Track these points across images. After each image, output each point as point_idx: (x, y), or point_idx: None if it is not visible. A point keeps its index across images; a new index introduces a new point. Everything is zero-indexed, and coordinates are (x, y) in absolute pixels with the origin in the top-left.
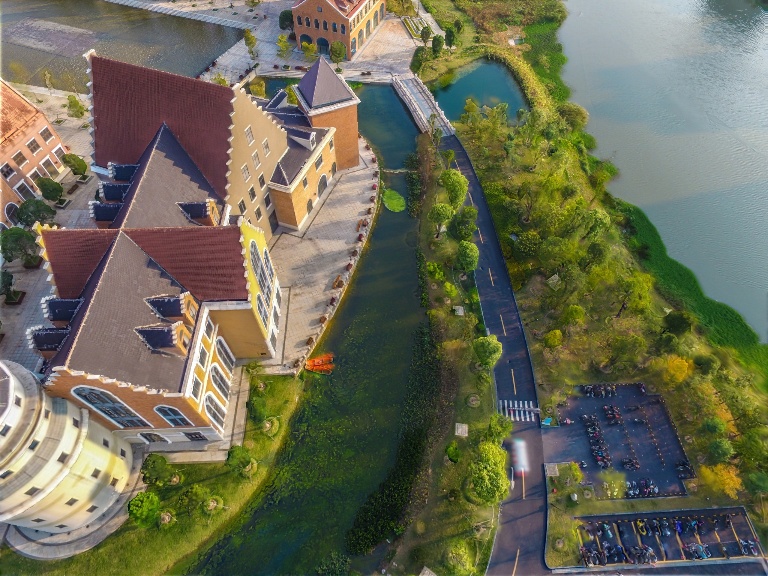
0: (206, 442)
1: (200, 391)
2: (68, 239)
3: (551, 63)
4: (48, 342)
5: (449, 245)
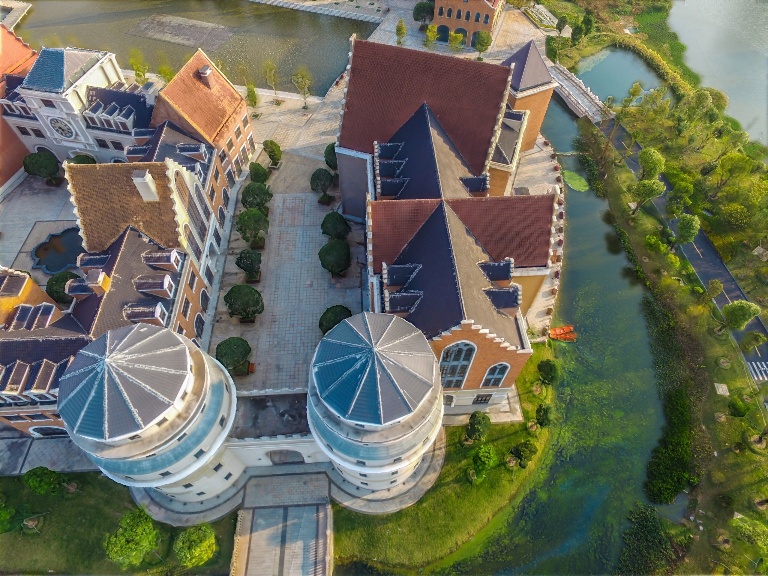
0: (486, 405)
1: None
2: (393, 209)
3: (672, 51)
4: (401, 304)
5: (647, 221)
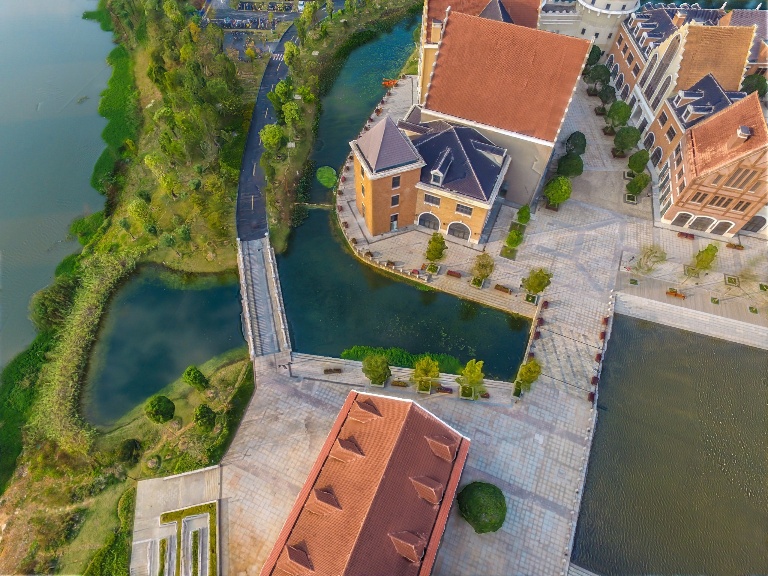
0: None
1: None
2: None
3: None
4: None
5: (290, 132)
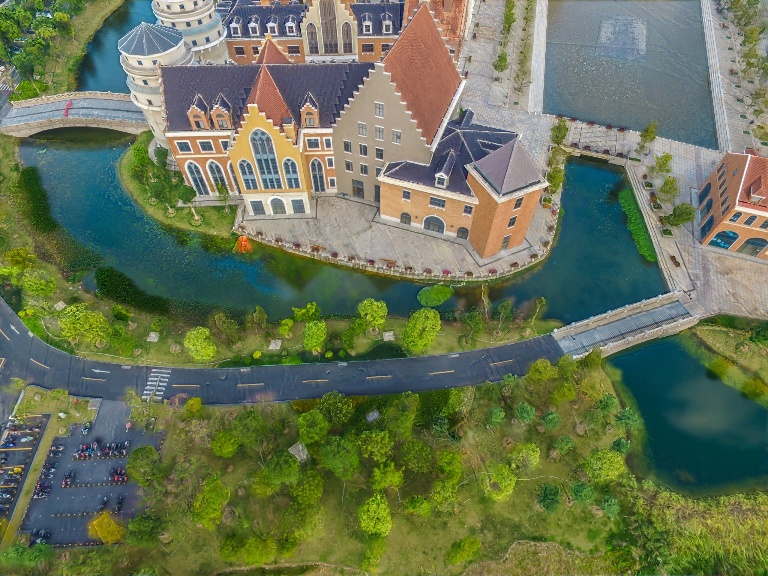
0: None
1: (187, 152)
2: None
3: None
4: None
5: (362, 341)
